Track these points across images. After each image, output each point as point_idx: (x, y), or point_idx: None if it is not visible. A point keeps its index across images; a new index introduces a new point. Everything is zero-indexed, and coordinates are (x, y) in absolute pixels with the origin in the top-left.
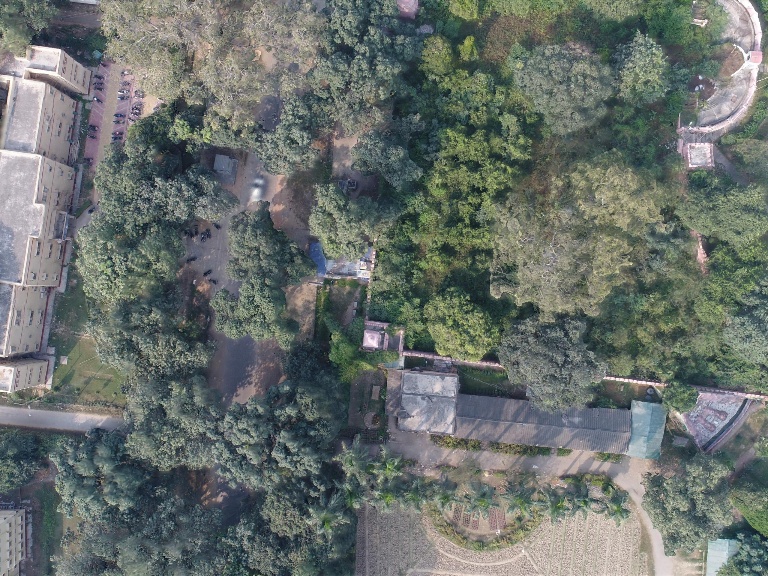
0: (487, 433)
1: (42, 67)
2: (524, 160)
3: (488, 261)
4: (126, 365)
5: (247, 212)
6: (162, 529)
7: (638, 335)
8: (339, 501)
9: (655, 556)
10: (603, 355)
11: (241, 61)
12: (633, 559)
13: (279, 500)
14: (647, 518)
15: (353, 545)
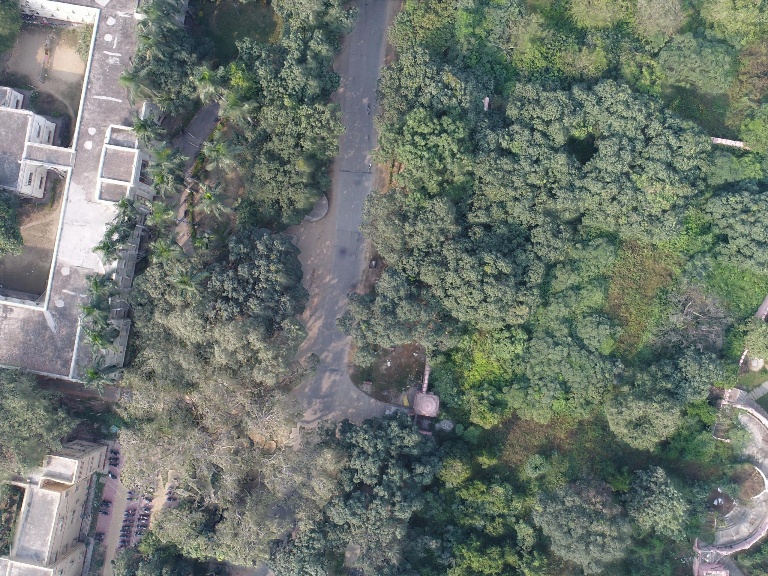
0: None
1: (58, 474)
2: (538, 575)
3: None
4: None
5: None
6: None
7: None
8: None
9: None
10: None
11: (259, 510)
12: None
13: None
14: None
15: None
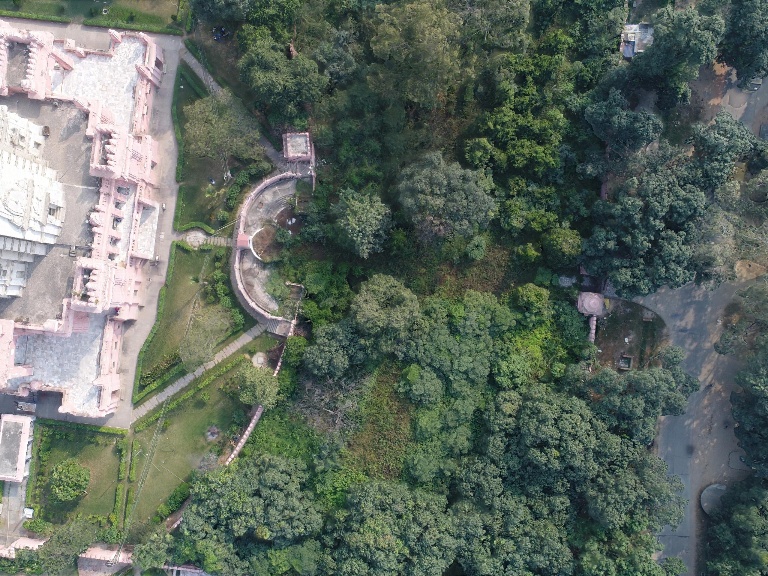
0: None
1: None
2: None
3: (510, 38)
4: None
5: (764, 73)
6: None
7: None
8: None
9: None
10: None
11: None
12: None
13: None
14: None
15: None
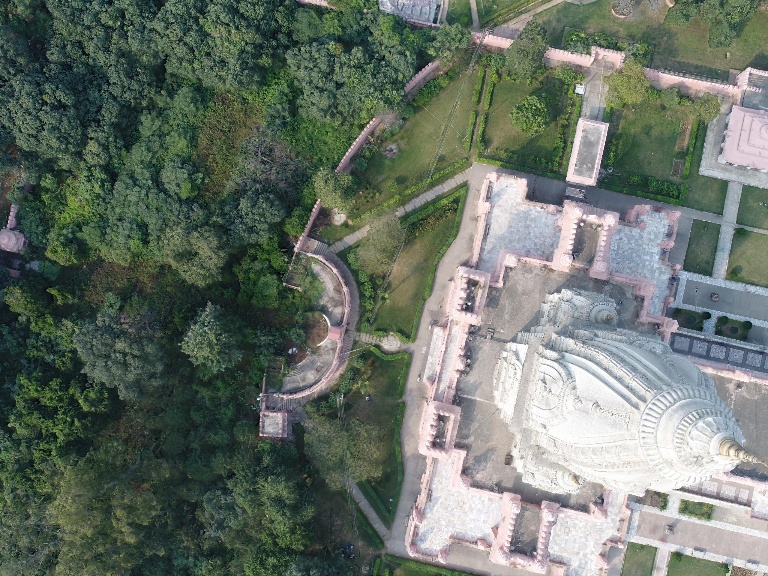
0: None
1: None
2: (101, 411)
3: None
4: None
5: None
6: None
7: None
8: None
9: None
10: None
11: None
12: None
13: None
14: None
15: None
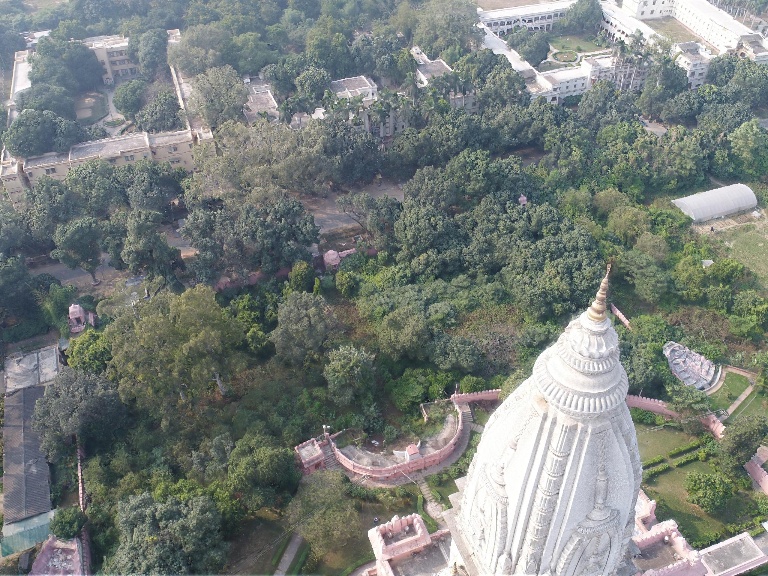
0: (11, 416)
1: (202, 137)
2: None
3: None
4: (24, 197)
5: None
6: None
7: (126, 476)
8: None
9: None
10: (100, 458)
11: None
12: None
13: None
14: None
15: None
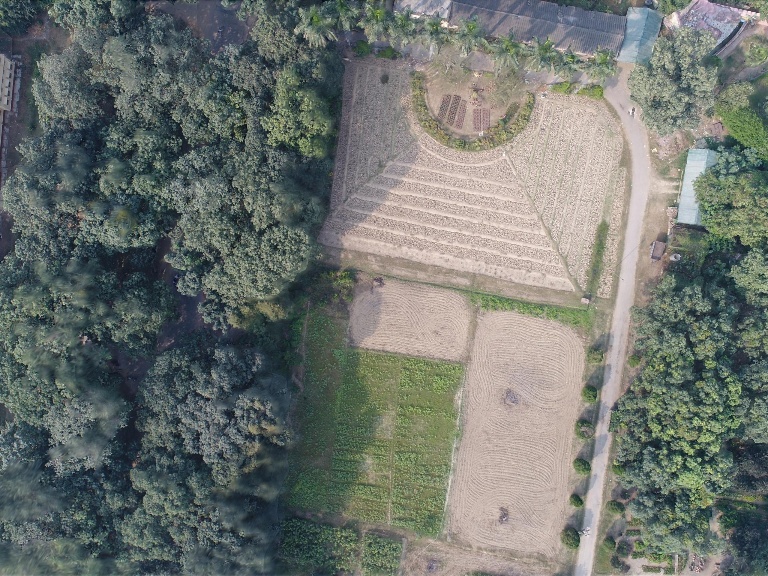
0: (482, 24)
1: None
2: None
3: None
4: None
5: None
6: (151, 35)
7: None
8: (329, 10)
9: (634, 172)
10: None
11: None
12: (612, 174)
13: (270, 20)
14: (630, 133)
15: (336, 128)
